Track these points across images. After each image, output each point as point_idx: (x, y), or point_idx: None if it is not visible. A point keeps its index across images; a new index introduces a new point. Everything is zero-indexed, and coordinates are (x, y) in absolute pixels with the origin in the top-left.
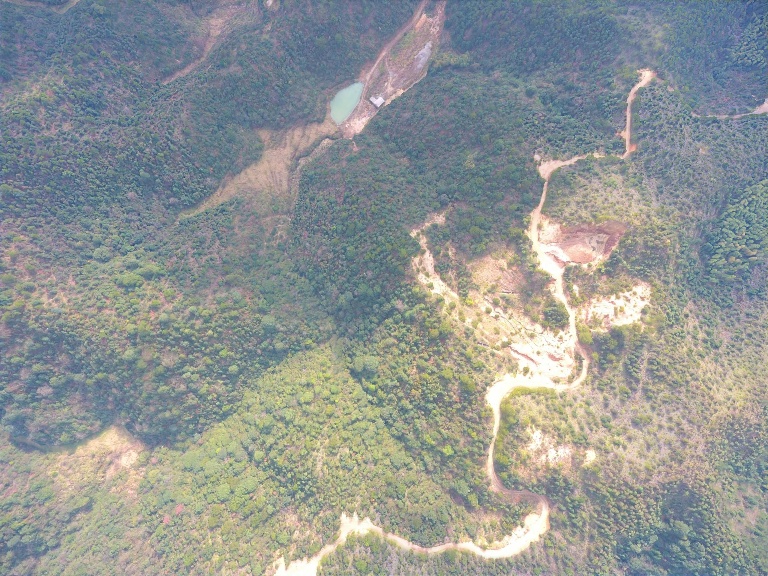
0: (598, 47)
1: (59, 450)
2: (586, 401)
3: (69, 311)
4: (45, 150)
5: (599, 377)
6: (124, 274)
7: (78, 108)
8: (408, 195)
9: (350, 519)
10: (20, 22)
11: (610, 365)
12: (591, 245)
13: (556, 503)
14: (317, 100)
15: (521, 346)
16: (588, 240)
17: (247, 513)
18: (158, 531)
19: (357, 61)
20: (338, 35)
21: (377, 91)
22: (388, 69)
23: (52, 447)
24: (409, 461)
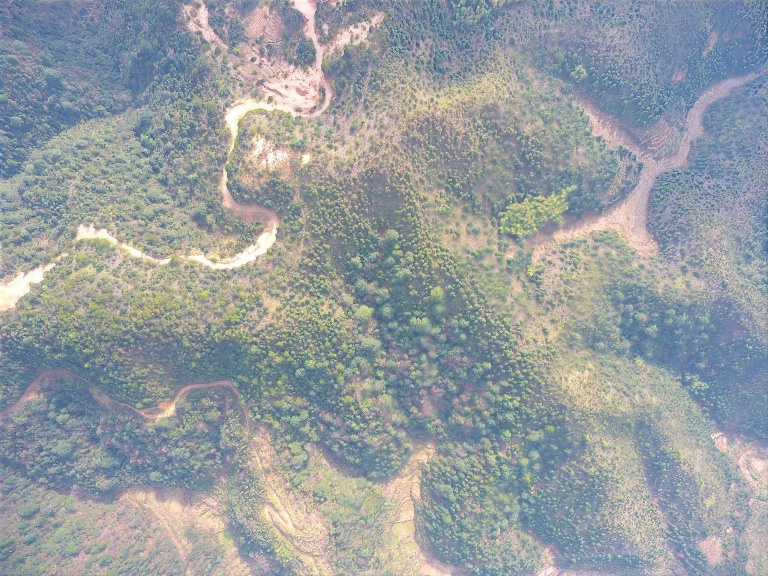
0: None
1: None
2: None
3: None
4: None
5: (335, 103)
6: None
7: None
8: None
9: (87, 229)
10: None
11: (344, 90)
12: None
13: (283, 217)
14: None
15: None
16: None
17: None
18: None
19: None
20: None
21: None
22: None
23: None
24: (166, 197)
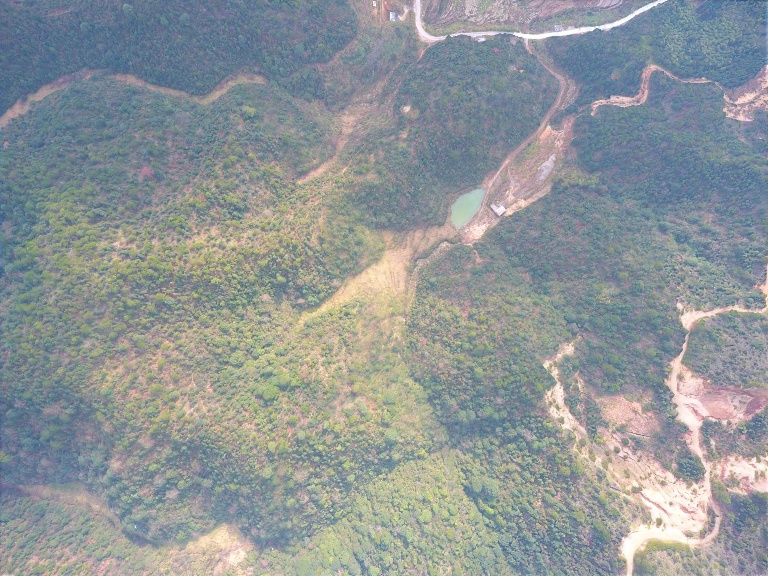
0: (737, 193)
1: (170, 544)
2: (721, 562)
3: (210, 423)
4: (197, 258)
5: (734, 538)
6: (259, 382)
7: (226, 212)
8: (536, 319)
9: None
10: (171, 117)
11: (746, 528)
12: (733, 404)
13: None
14: (441, 205)
15: (651, 493)
16: (730, 398)
17: None
18: None
19: (484, 170)
20: (473, 149)
21: (498, 198)
22: (510, 177)
23: (163, 541)
24: None
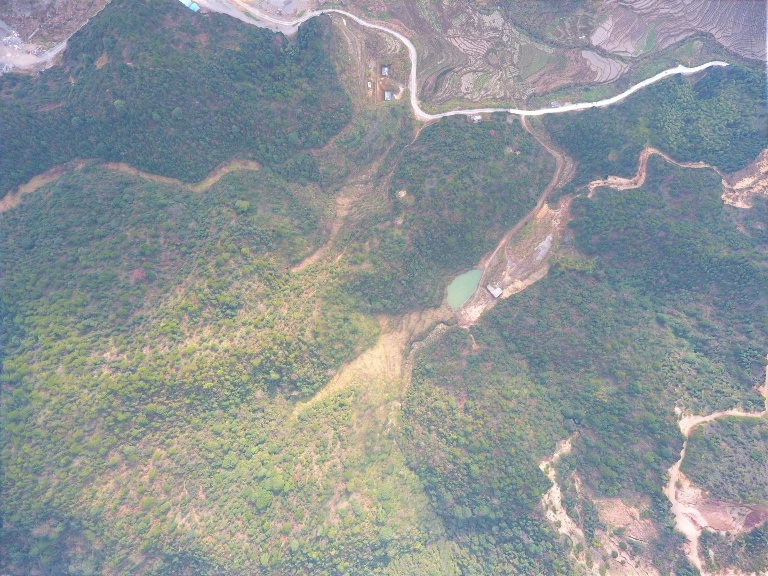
0: (735, 288)
1: None
2: None
3: (202, 534)
4: (189, 363)
5: None
6: (252, 485)
7: (219, 312)
8: (533, 413)
9: None
10: (163, 211)
11: None
12: (732, 515)
13: None
14: (437, 287)
15: None
16: (729, 510)
17: None
18: None
19: (480, 252)
20: (469, 235)
21: (494, 279)
22: (507, 257)
23: None
24: None
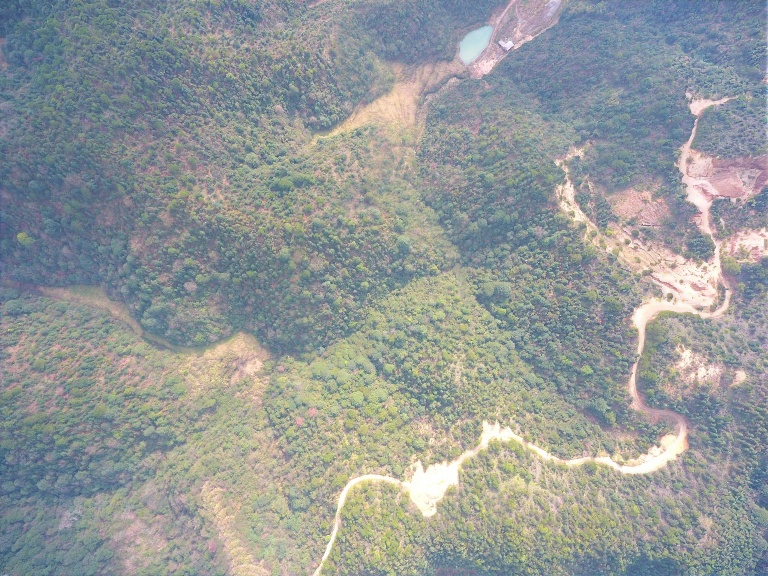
0: None
1: (188, 352)
2: (732, 327)
3: (228, 207)
4: None
5: (744, 306)
6: None
7: (239, 16)
8: (546, 130)
9: (492, 427)
10: None
11: (756, 295)
12: (742, 180)
13: (696, 424)
14: (449, 38)
15: (662, 275)
16: (739, 175)
17: (383, 418)
18: (290, 432)
19: (491, 3)
20: None
21: (506, 35)
22: (518, 15)
23: (181, 348)
24: (541, 381)
